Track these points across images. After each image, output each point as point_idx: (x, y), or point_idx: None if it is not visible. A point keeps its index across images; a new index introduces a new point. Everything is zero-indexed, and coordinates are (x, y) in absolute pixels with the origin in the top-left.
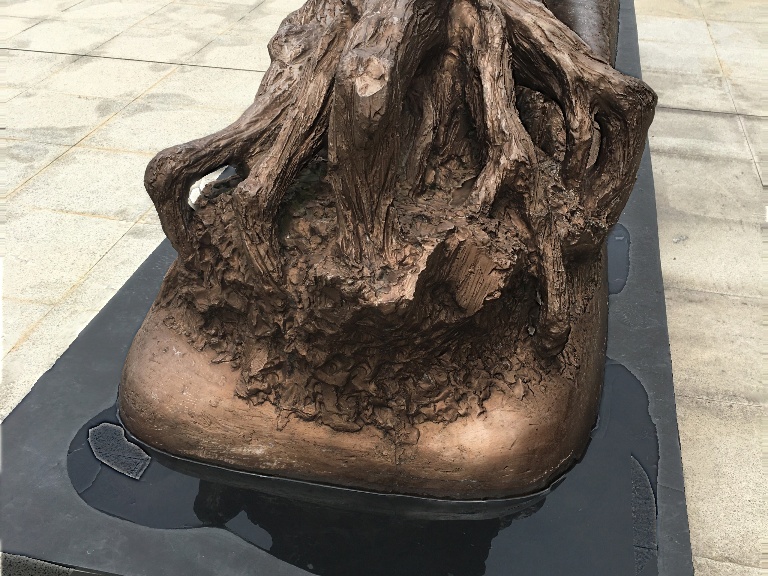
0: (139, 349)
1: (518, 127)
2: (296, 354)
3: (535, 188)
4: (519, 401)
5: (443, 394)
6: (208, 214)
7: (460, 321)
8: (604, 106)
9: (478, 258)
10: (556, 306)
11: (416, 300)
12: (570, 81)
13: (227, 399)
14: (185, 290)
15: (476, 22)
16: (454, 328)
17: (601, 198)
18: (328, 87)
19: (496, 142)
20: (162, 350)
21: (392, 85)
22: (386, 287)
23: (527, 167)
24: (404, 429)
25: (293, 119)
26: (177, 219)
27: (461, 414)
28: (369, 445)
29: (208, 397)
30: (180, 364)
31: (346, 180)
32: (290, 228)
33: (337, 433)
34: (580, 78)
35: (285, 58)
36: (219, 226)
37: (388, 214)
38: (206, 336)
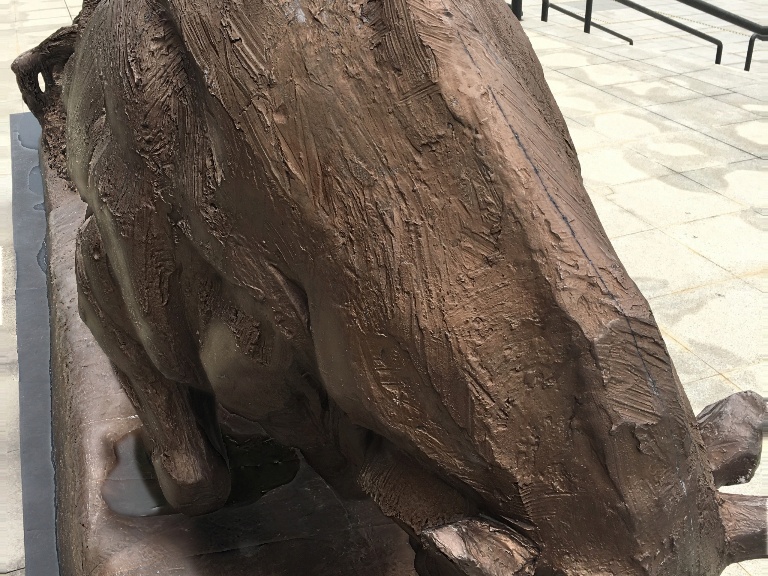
0: None
1: None
2: None
3: None
4: None
5: None
6: None
7: None
8: None
9: None
10: None
11: None
12: None
13: None
14: None
15: None
16: None
17: None
18: None
19: None
20: None
21: None
22: None
23: None
24: None
25: None
26: None
27: None
28: None
29: None
30: None
31: None
32: None
33: None
34: None
35: None
36: None
37: None
38: None
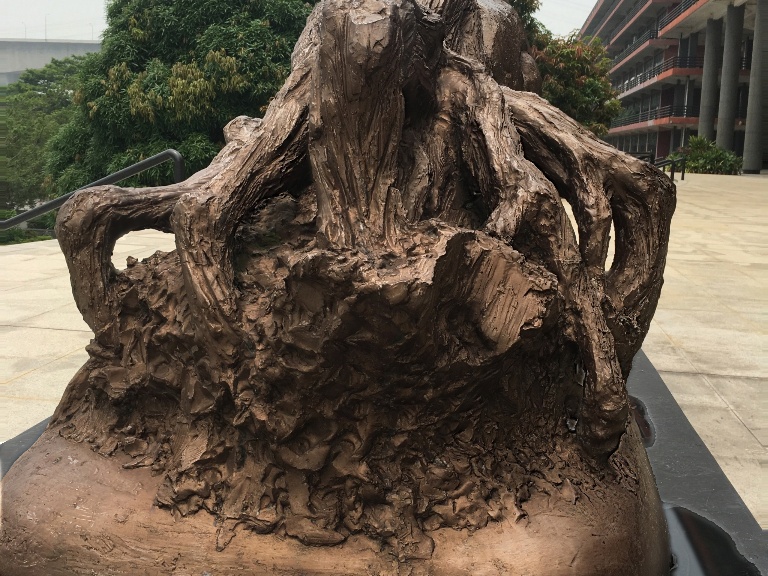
0: (18, 466)
1: (533, 168)
2: (251, 426)
3: (562, 231)
4: (571, 505)
5: (465, 486)
6: (137, 270)
7: (488, 363)
8: (619, 190)
9: (508, 274)
10: (607, 373)
11: (433, 299)
12: (578, 158)
13: (142, 510)
14: (95, 373)
15: (469, 86)
16: (478, 381)
17: (627, 296)
18: (301, 112)
19: (508, 183)
20: (52, 461)
21: (395, 23)
22: (392, 272)
23: (551, 201)
24: (411, 536)
25: (257, 138)
26: (94, 273)
27: (493, 516)
28: (358, 563)
29: (113, 509)
30: (76, 473)
31: (333, 148)
32: (248, 267)
33: (309, 548)
34: (589, 155)
35: (244, 137)
36: (150, 283)
37: (389, 195)
38: (118, 437)
